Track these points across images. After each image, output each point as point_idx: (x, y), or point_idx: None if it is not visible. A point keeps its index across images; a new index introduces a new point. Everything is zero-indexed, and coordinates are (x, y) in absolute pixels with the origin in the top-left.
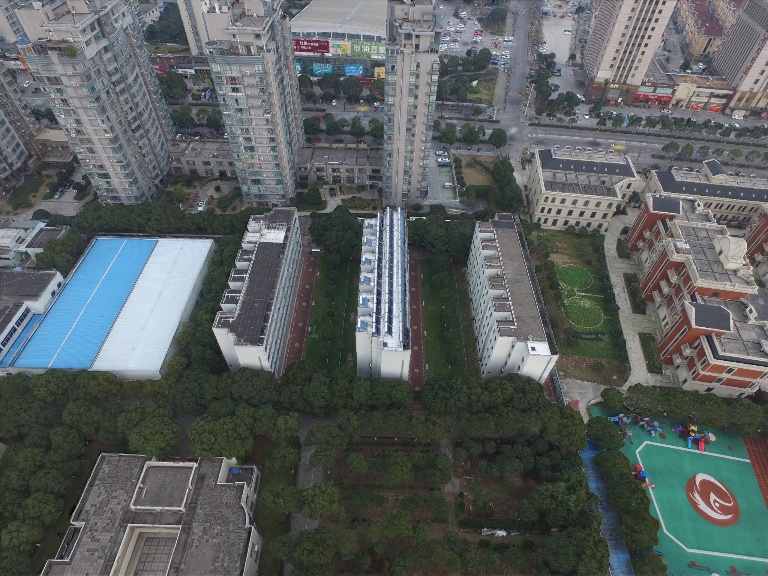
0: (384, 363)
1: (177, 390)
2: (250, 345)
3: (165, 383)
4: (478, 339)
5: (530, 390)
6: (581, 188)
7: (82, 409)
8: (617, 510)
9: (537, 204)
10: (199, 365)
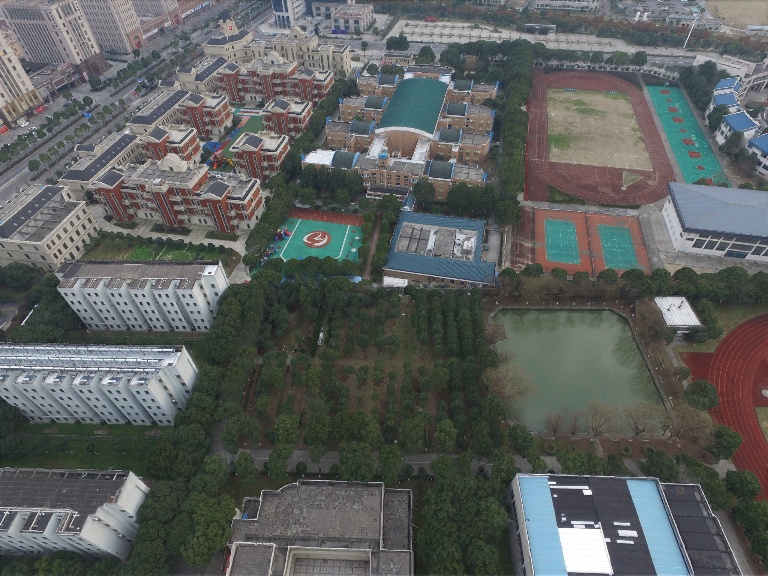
0: (183, 376)
1: None
2: (122, 487)
3: None
4: (174, 327)
5: (237, 289)
6: (49, 224)
7: None
8: (318, 273)
9: (45, 258)
10: (111, 575)
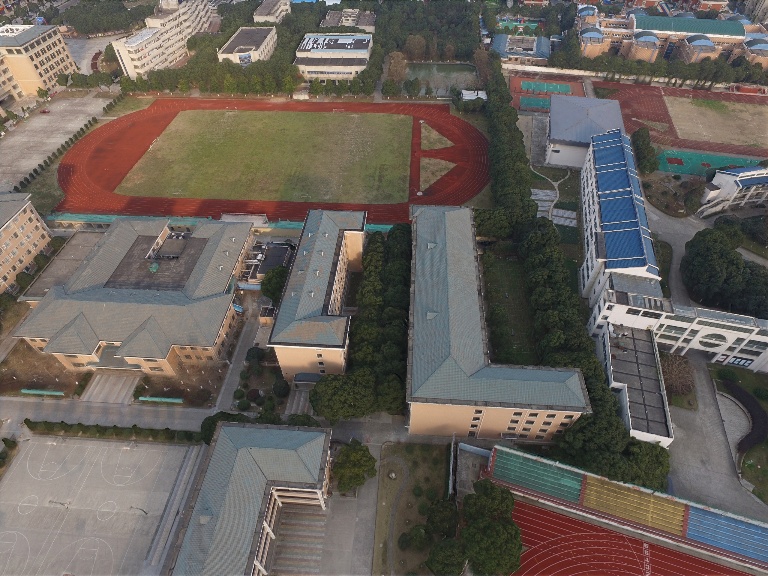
0: None
1: (348, 2)
2: None
3: (344, 1)
4: None
5: None
6: None
7: (320, 5)
8: None
9: None
10: None
